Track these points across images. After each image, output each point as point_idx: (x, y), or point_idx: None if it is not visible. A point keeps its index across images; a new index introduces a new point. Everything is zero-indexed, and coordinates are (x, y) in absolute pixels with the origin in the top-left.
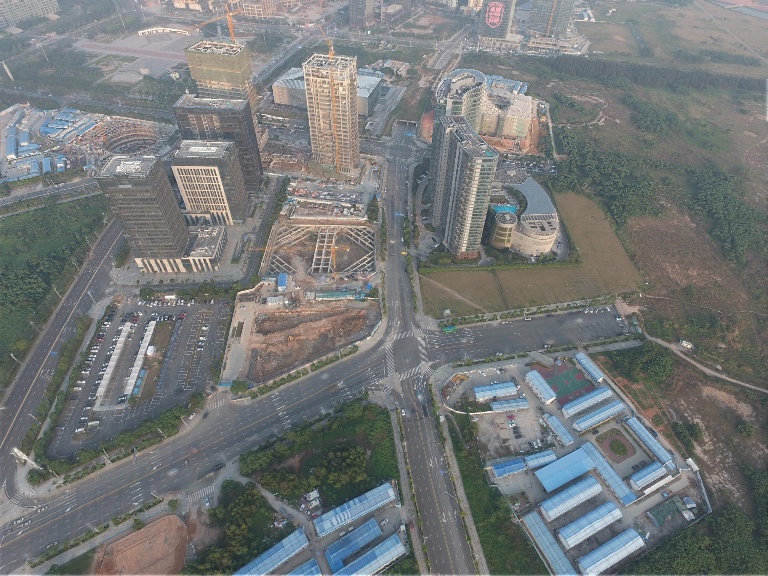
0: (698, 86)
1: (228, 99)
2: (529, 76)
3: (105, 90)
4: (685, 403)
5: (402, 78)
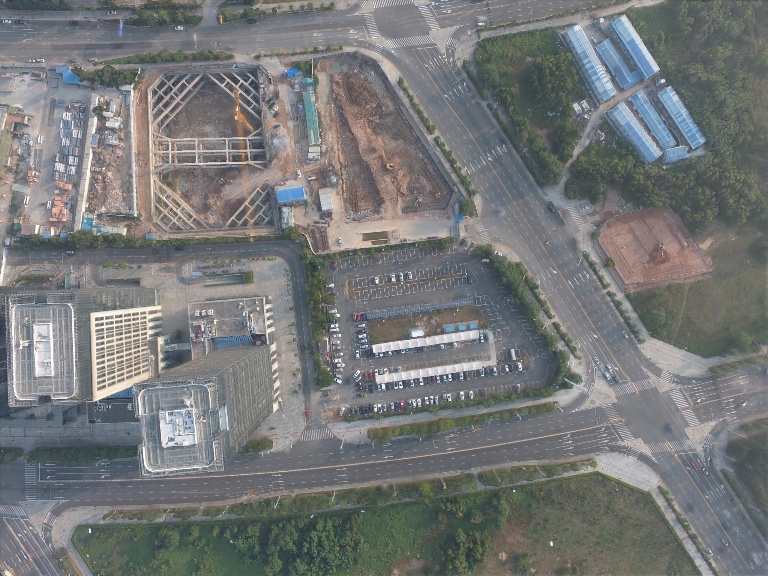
0: None
1: None
2: None
3: None
4: None
5: None
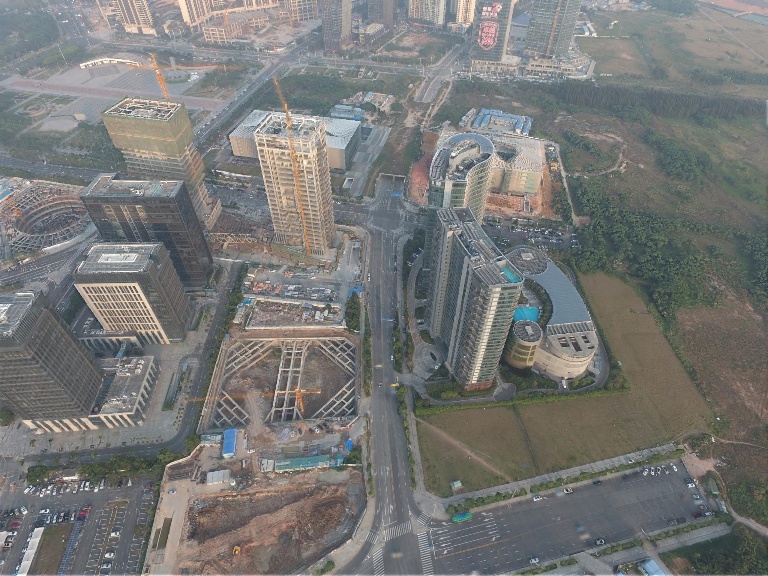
0: (726, 116)
1: (157, 180)
2: (532, 108)
3: (29, 144)
4: None
5: (385, 115)
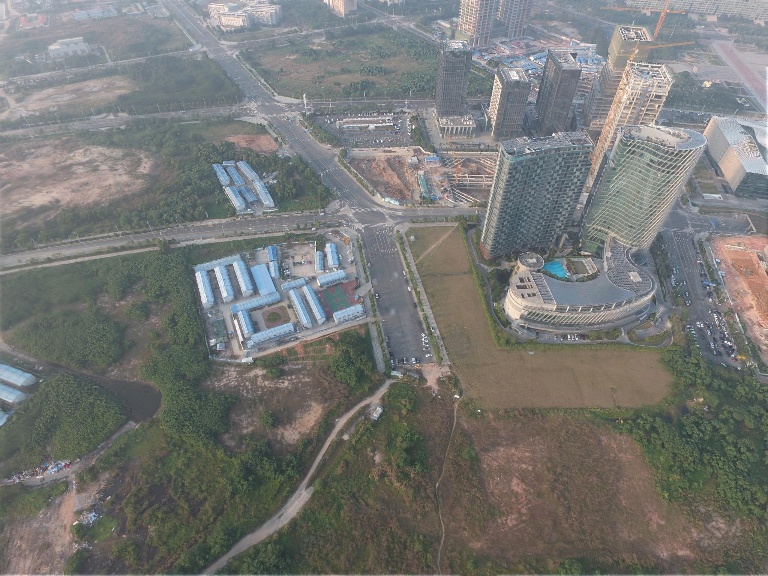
0: None
1: None
2: None
3: None
4: (305, 381)
5: None
